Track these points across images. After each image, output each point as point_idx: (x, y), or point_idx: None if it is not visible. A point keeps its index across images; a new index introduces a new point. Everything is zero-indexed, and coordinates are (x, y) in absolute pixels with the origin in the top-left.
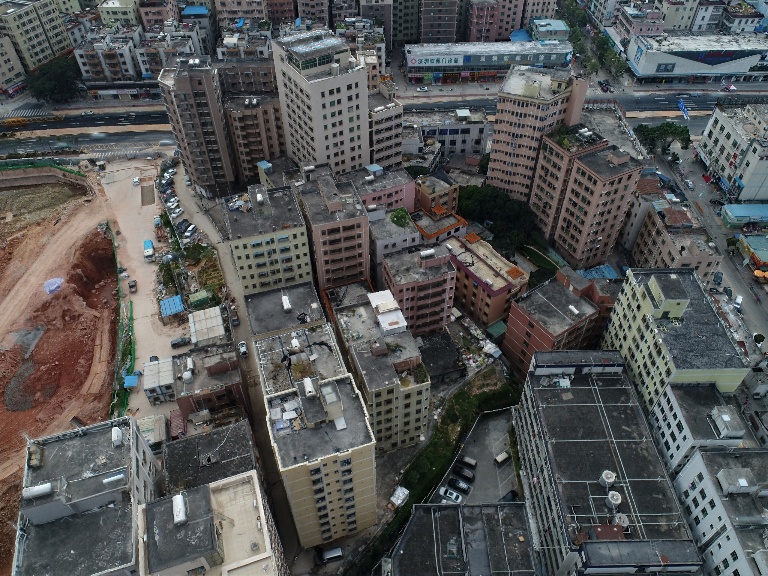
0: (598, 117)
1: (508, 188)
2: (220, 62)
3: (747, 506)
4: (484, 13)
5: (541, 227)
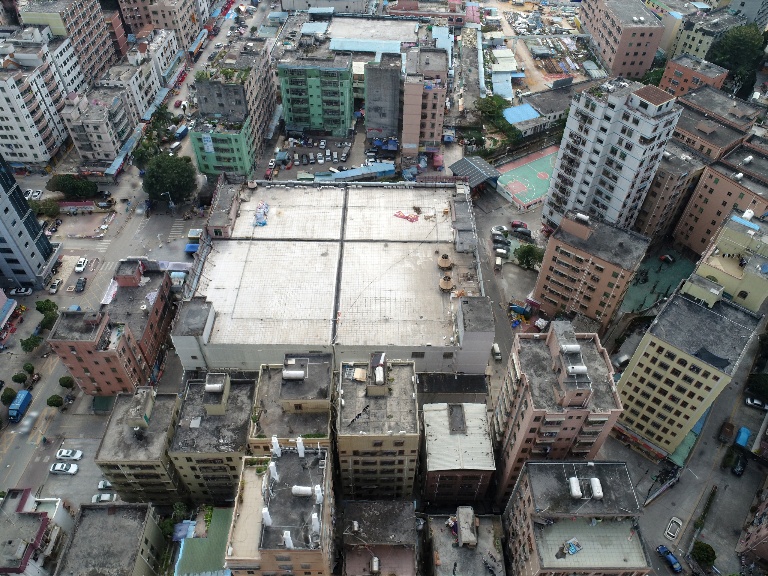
0: None
1: None
2: None
3: (3, 59)
4: None
5: None
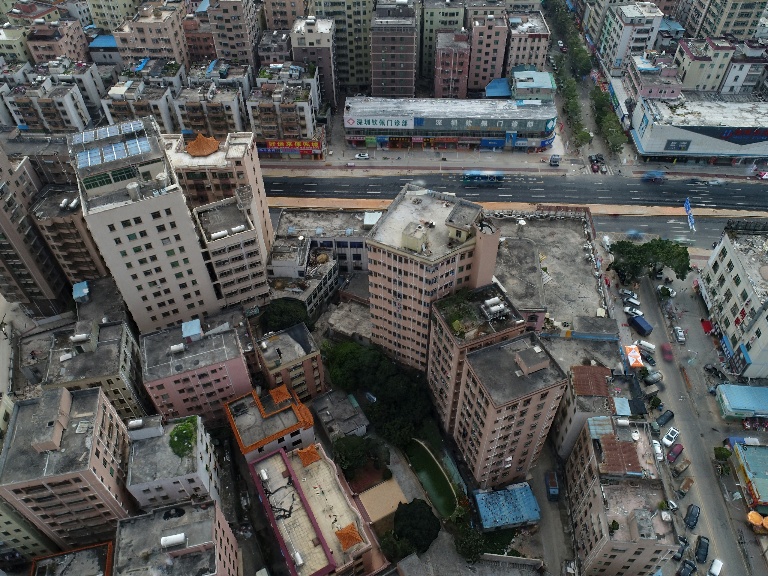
0: (560, 231)
1: (399, 351)
2: (42, 143)
3: None
4: (451, 60)
5: (440, 413)
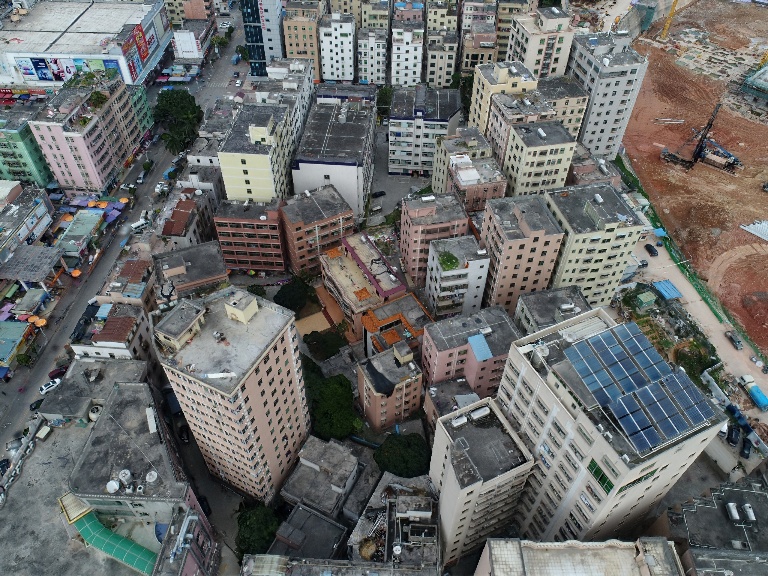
0: None
1: None
2: None
3: None
4: None
5: None
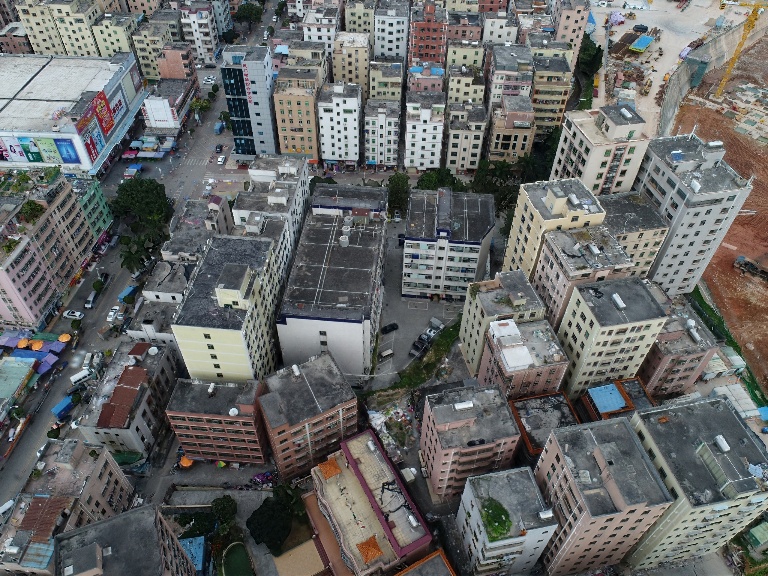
0: None
1: None
2: None
3: None
4: None
5: None
